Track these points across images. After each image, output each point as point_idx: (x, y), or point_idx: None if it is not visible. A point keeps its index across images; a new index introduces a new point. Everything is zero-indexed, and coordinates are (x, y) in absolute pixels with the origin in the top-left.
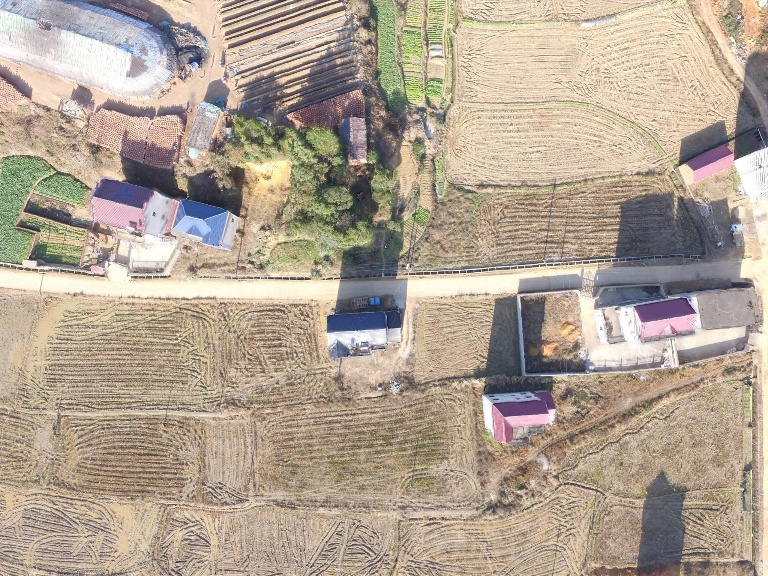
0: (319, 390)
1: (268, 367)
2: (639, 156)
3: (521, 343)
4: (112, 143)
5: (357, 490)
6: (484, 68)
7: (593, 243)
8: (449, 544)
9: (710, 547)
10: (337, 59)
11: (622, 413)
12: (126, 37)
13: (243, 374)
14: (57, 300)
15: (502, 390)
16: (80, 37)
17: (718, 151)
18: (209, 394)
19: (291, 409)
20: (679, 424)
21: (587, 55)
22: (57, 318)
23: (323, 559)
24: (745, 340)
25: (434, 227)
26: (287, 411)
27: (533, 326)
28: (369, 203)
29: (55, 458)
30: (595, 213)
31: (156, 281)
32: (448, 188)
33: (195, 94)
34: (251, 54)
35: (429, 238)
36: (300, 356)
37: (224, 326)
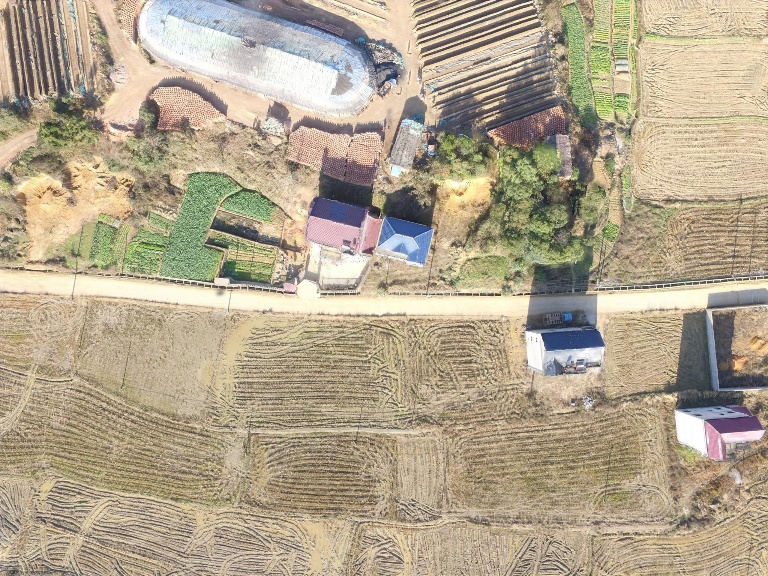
0: (511, 406)
1: (459, 383)
2: None
3: (713, 358)
4: (312, 161)
5: (550, 506)
6: (668, 83)
7: None
8: (642, 559)
9: None
10: (534, 75)
11: None
12: (331, 54)
13: (434, 391)
14: (245, 317)
15: (694, 405)
16: (286, 55)
17: None
18: (400, 411)
19: (484, 425)
20: None
21: None
22: (245, 335)
23: (517, 575)
24: None
25: (623, 242)
26: (479, 427)
27: (723, 341)
28: None
29: (246, 476)
30: None
31: (345, 298)
32: (636, 203)
33: (392, 111)
34: (447, 71)
35: (618, 253)
36: (491, 372)
37: (414, 343)
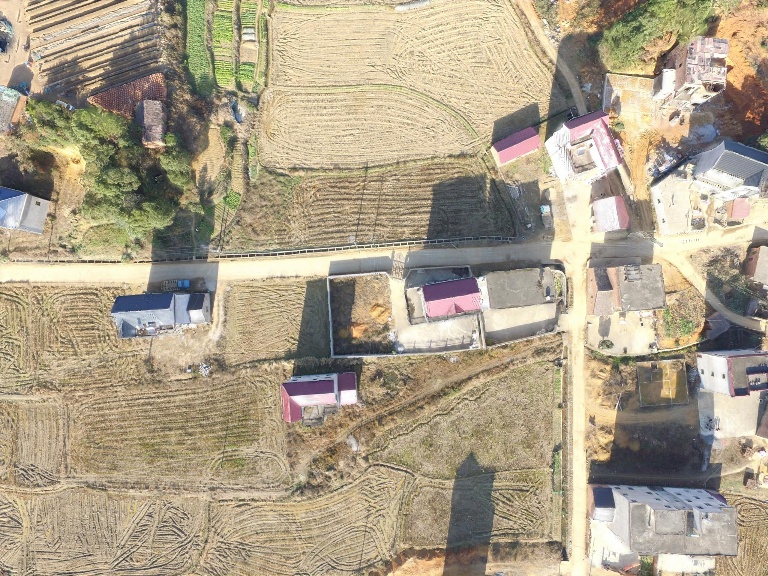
0: (130, 372)
1: (80, 350)
2: (452, 138)
3: (329, 325)
4: None
5: (167, 472)
6: (299, 52)
7: (405, 225)
8: (259, 525)
9: (519, 528)
10: (140, 43)
11: (431, 394)
12: None
13: (55, 357)
14: None
15: (311, 372)
16: None
17: (524, 133)
18: (22, 377)
19: (102, 391)
20: (489, 405)
21: (401, 38)
22: None
23: (134, 540)
24: (555, 321)
25: (245, 210)
26: (98, 393)
27: (343, 308)
28: (172, 186)
29: None
30: (407, 195)
31: None
32: (260, 171)
33: None
34: (55, 38)
35: (241, 221)
36: (112, 339)
37: (37, 309)
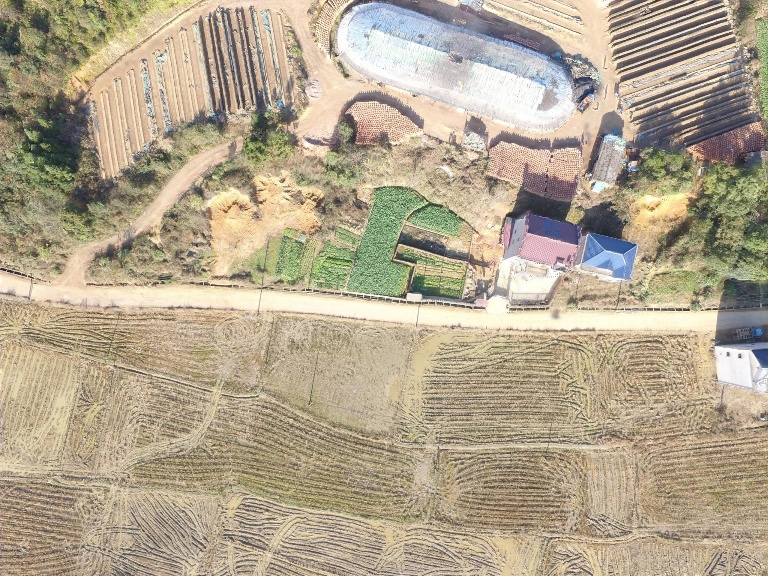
0: (700, 421)
1: (648, 398)
2: None
3: None
4: (513, 176)
5: (740, 520)
6: None
7: None
8: None
9: None
10: (731, 91)
11: None
12: (536, 70)
13: (623, 406)
14: (432, 333)
15: None
16: (493, 70)
17: None
18: (590, 426)
19: (674, 440)
20: None
21: None
22: (433, 351)
23: None
24: None
25: None
26: (669, 442)
27: None
28: None
29: (435, 492)
30: None
31: (534, 313)
32: None
33: (589, 126)
34: (644, 86)
35: None
36: (679, 387)
37: (602, 358)
